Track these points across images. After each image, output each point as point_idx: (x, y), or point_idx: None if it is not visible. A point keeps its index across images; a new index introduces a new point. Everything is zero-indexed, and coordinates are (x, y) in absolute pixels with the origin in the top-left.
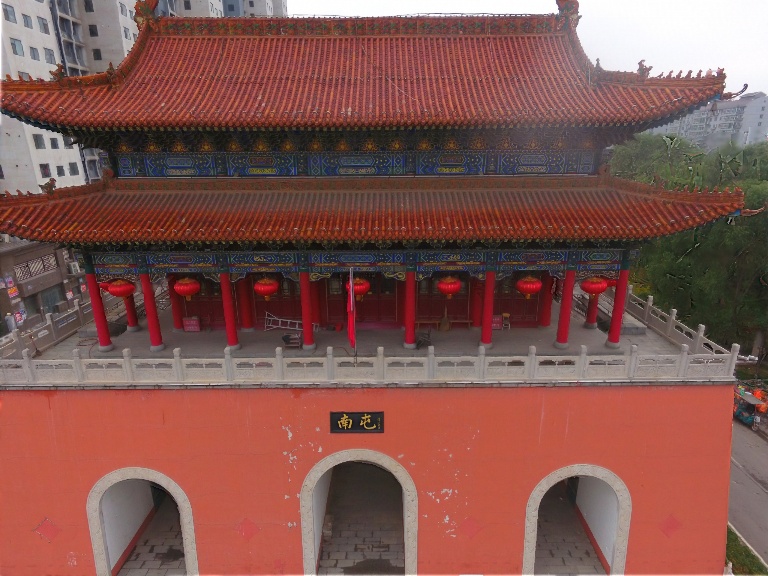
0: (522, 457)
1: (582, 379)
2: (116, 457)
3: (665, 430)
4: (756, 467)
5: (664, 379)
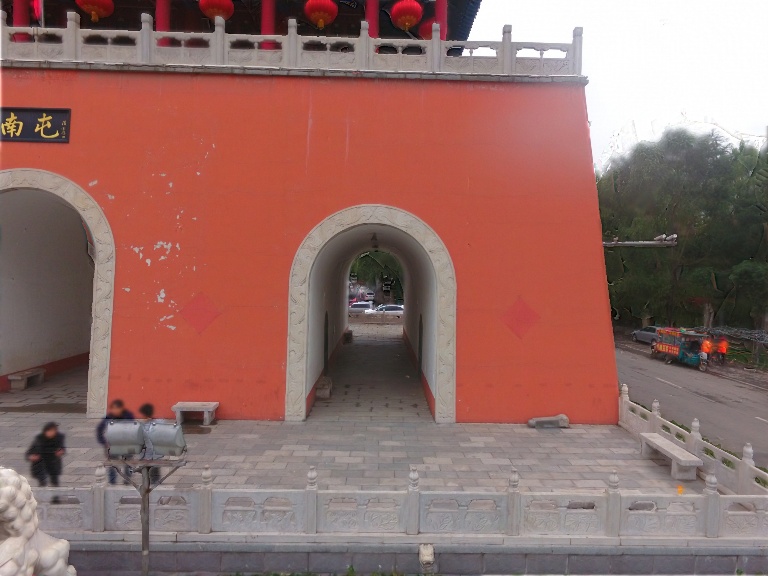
0: (281, 190)
1: (364, 69)
2: None
3: (495, 155)
4: (701, 388)
5: (482, 73)
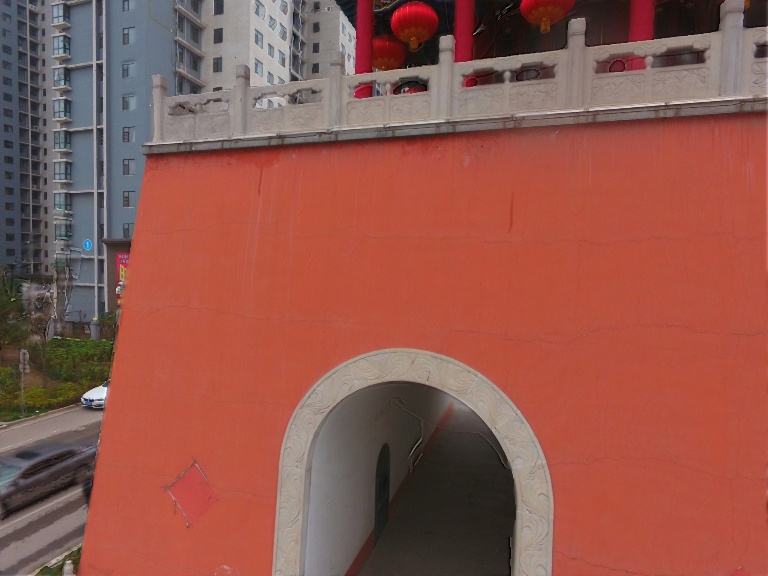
0: None
1: None
2: (373, 318)
3: None
4: None
5: None
